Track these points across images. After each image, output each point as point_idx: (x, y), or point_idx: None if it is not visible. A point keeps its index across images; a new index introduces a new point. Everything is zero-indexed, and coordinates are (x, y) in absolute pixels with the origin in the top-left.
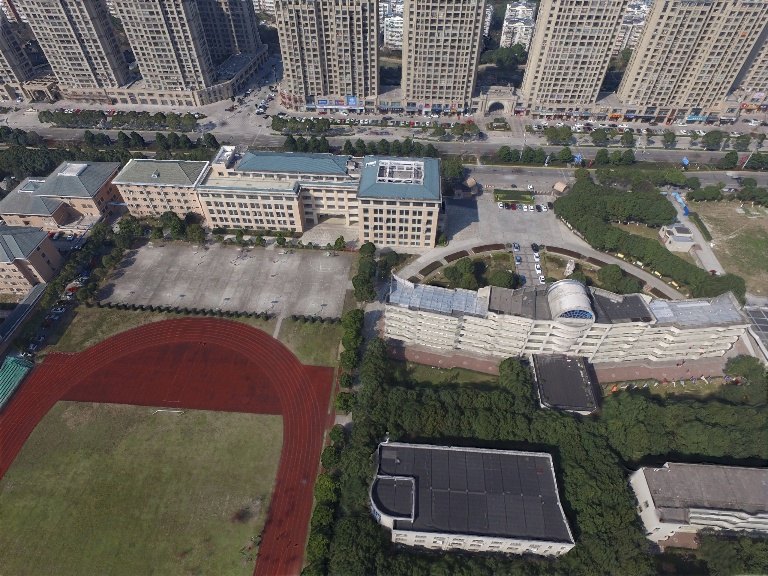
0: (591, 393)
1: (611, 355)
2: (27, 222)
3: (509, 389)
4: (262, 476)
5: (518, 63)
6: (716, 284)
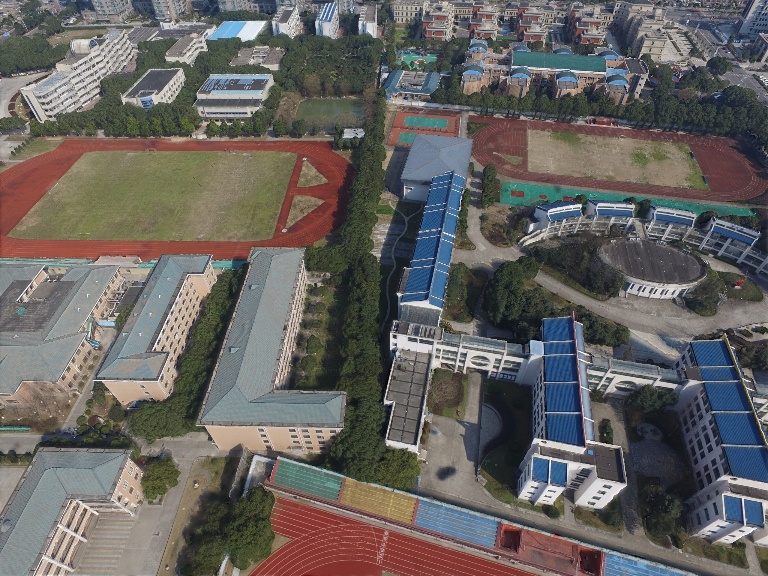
0: (131, 72)
1: (116, 70)
2: None
3: None
4: (117, 154)
5: None
6: None
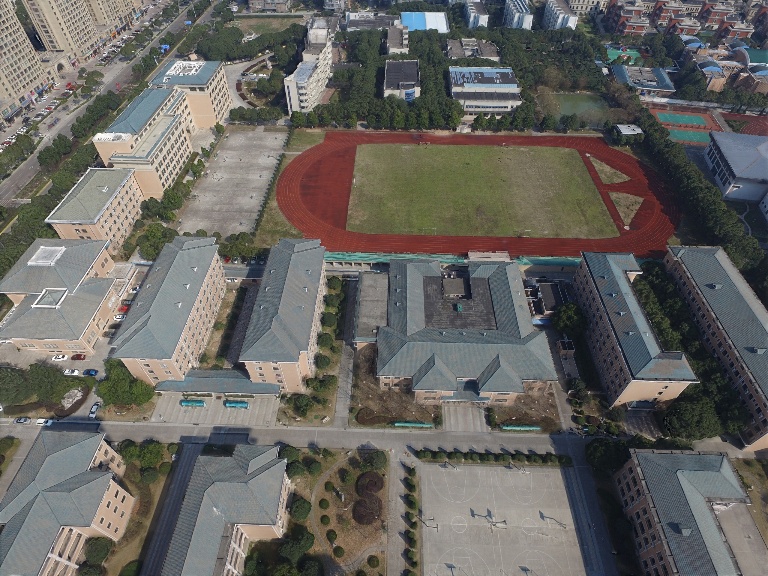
0: (351, 63)
1: None
2: (97, 325)
3: (352, 72)
4: (391, 147)
5: None
6: (298, 27)
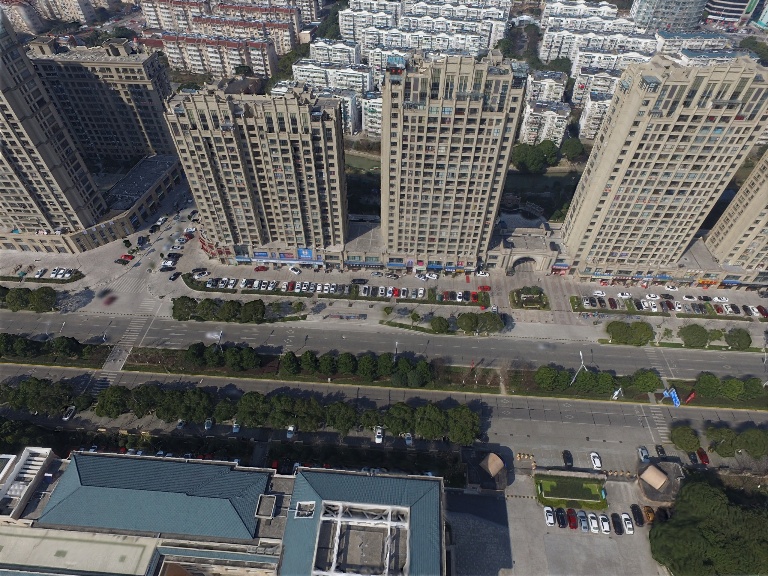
0: None
1: None
2: None
3: None
4: None
5: (547, 165)
6: None
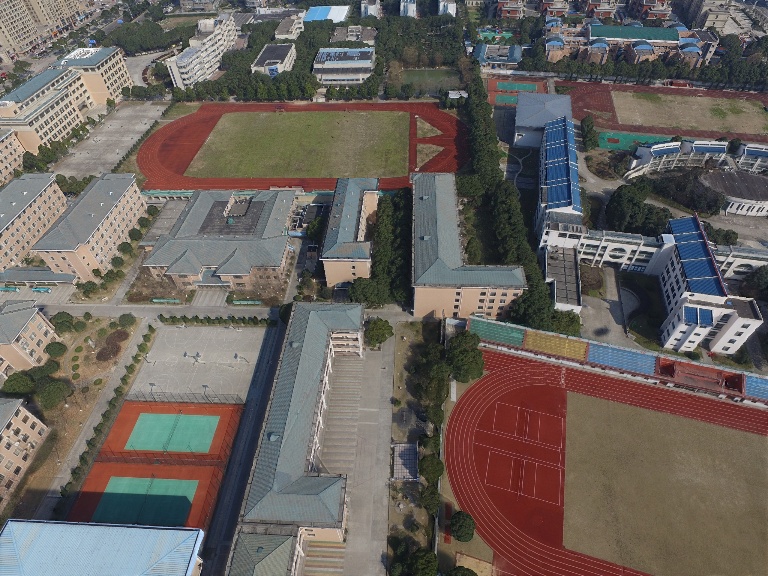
0: (244, 49)
1: None
2: None
3: None
4: (251, 114)
5: None
6: None
